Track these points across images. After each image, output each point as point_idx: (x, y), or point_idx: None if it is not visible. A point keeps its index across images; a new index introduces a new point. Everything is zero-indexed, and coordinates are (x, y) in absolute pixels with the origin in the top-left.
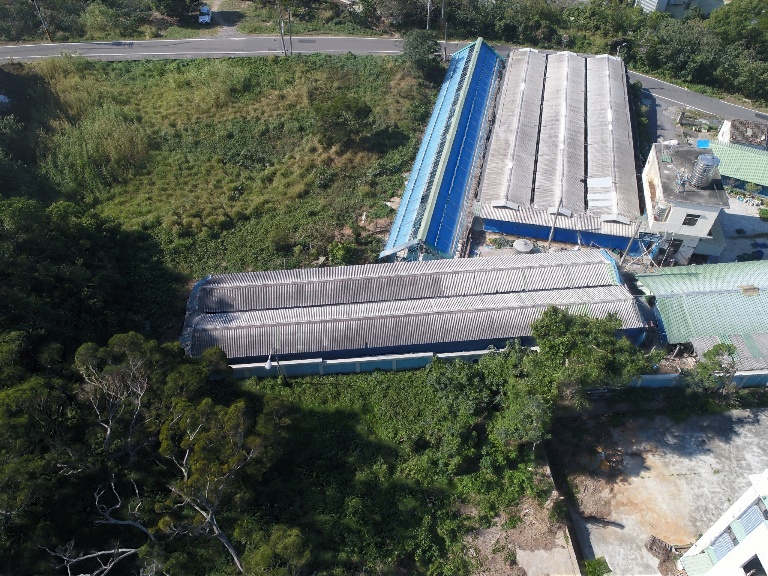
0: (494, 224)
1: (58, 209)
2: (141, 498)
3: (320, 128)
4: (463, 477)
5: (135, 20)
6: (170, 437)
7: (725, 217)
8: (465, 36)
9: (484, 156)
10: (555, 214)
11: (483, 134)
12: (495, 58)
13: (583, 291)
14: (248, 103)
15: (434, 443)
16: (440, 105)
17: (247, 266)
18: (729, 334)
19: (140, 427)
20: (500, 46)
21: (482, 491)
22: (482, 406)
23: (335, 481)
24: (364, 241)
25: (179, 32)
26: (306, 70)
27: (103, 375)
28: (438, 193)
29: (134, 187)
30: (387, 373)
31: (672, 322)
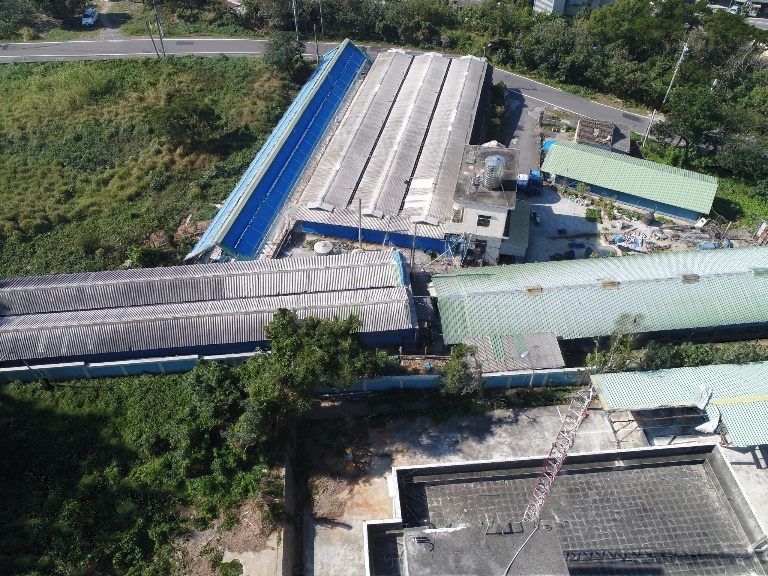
0: (311, 226)
1: None
2: None
3: (163, 130)
4: (196, 479)
5: (15, 22)
6: None
7: (551, 217)
8: (347, 37)
9: None
10: (368, 215)
11: (326, 136)
12: (361, 59)
13: (363, 292)
14: (105, 105)
15: (173, 446)
16: (292, 107)
17: (51, 269)
18: (505, 334)
19: None
20: (380, 47)
21: (207, 493)
22: (224, 408)
23: (60, 485)
24: (181, 243)
25: (60, 34)
26: (173, 72)
27: None
28: (251, 195)
29: None
30: (156, 376)
31: (450, 323)
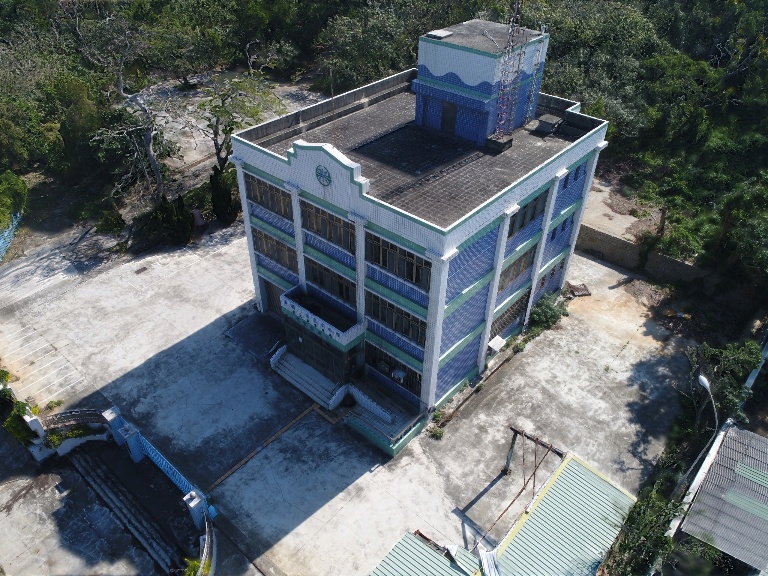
0: None
1: None
2: None
3: None
4: None
5: None
6: None
7: None
8: None
9: None
10: None
11: None
12: None
13: None
14: None
15: None
16: None
17: None
18: None
19: None
20: None
21: None
22: None
23: None
24: None
25: None
26: None
27: None
28: None
29: None
30: None
31: None
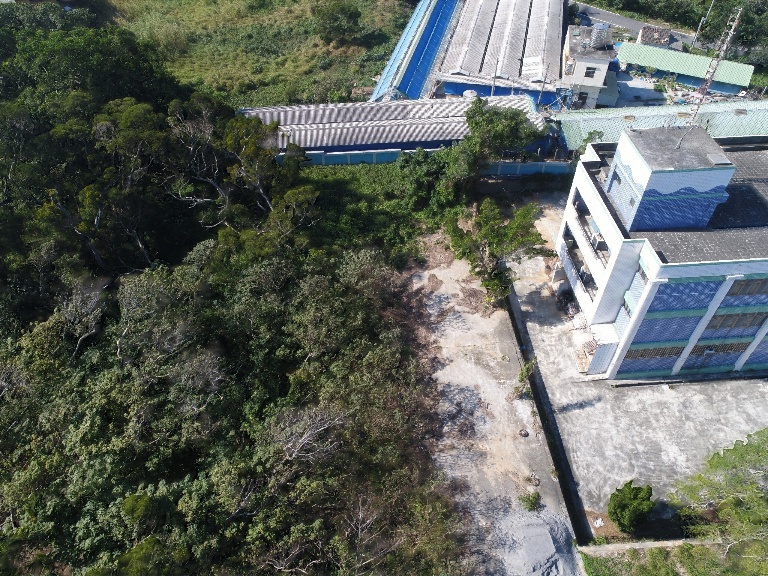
0: (452, 87)
1: (143, 41)
2: (207, 212)
3: (321, 28)
4: (418, 213)
5: None
6: None
7: (628, 89)
8: None
9: (447, 47)
10: (496, 78)
11: (448, 33)
12: None
13: None
14: (263, 15)
15: (400, 194)
16: (415, 15)
17: None
18: None
19: (211, 149)
20: None
21: (430, 216)
22: (432, 171)
23: (333, 209)
24: (354, 99)
25: None
26: None
27: (185, 122)
28: (409, 62)
29: (180, 64)
30: None
31: (571, 137)
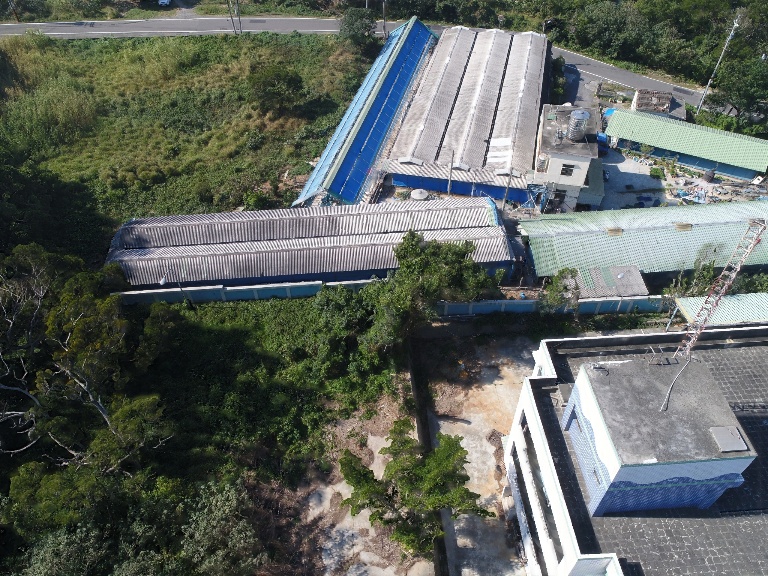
0: (401, 179)
1: None
2: None
3: (255, 96)
4: (334, 381)
5: (98, 2)
6: (57, 324)
7: (618, 175)
8: None
9: (403, 121)
10: (455, 169)
11: (405, 102)
12: (428, 35)
13: (463, 231)
14: (194, 76)
15: (311, 353)
16: (369, 77)
17: (172, 214)
18: None
19: (39, 323)
20: (440, 26)
21: (346, 390)
22: (354, 322)
23: (219, 381)
24: (283, 194)
25: (139, 13)
26: (252, 47)
27: (11, 281)
28: (349, 150)
29: (78, 147)
30: (283, 300)
31: (541, 258)
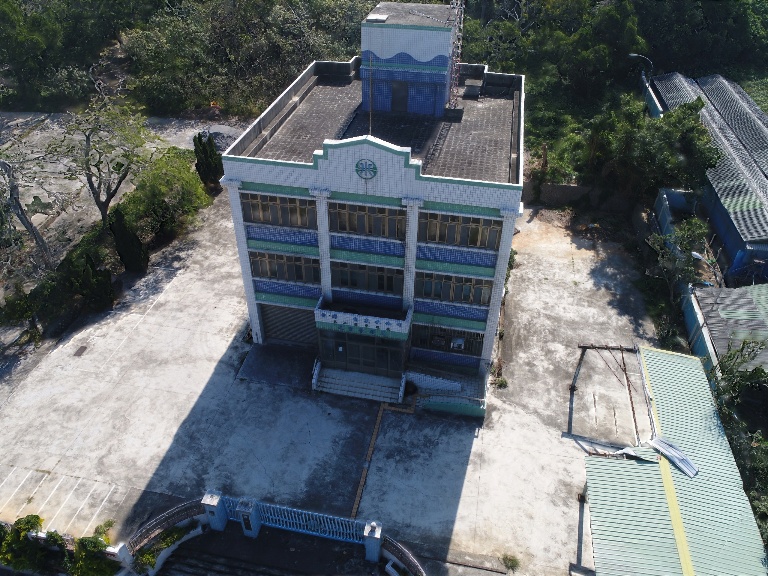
0: None
1: None
2: (556, 66)
3: None
4: None
5: None
6: None
7: None
8: None
9: None
10: None
11: None
12: None
13: None
14: None
15: None
16: None
17: (767, 112)
18: None
19: None
20: None
21: None
22: None
23: None
24: None
25: None
26: None
27: None
28: None
29: None
30: None
31: None
